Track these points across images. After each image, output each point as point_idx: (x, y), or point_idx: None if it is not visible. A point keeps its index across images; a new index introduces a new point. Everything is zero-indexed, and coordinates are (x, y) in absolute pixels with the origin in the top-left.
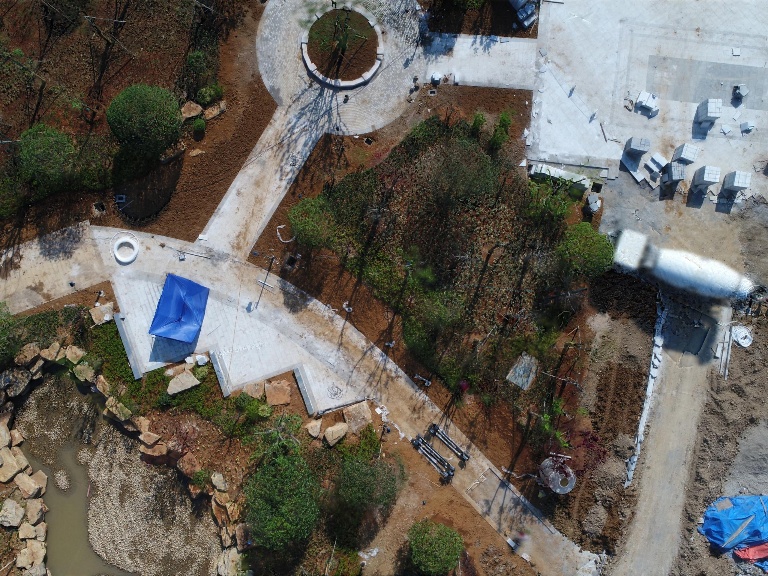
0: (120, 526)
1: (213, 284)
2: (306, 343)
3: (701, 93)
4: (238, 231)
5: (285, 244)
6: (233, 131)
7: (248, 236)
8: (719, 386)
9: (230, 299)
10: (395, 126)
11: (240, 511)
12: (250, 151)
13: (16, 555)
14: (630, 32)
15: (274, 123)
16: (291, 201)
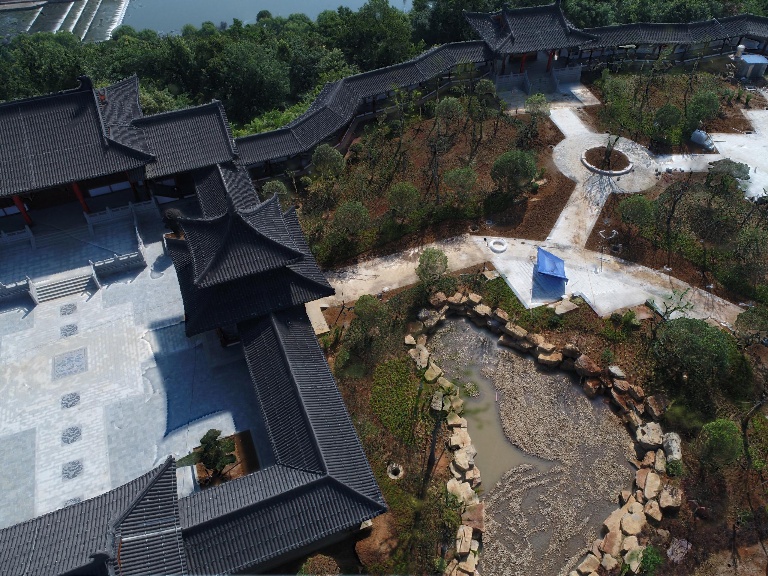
0: (532, 421)
1: (565, 260)
2: (647, 288)
3: None
4: (573, 235)
5: (608, 240)
6: (554, 192)
7: (581, 237)
8: None
9: (580, 267)
10: (655, 188)
11: (643, 391)
12: (567, 201)
13: (447, 438)
14: None
15: (577, 190)
16: (603, 220)
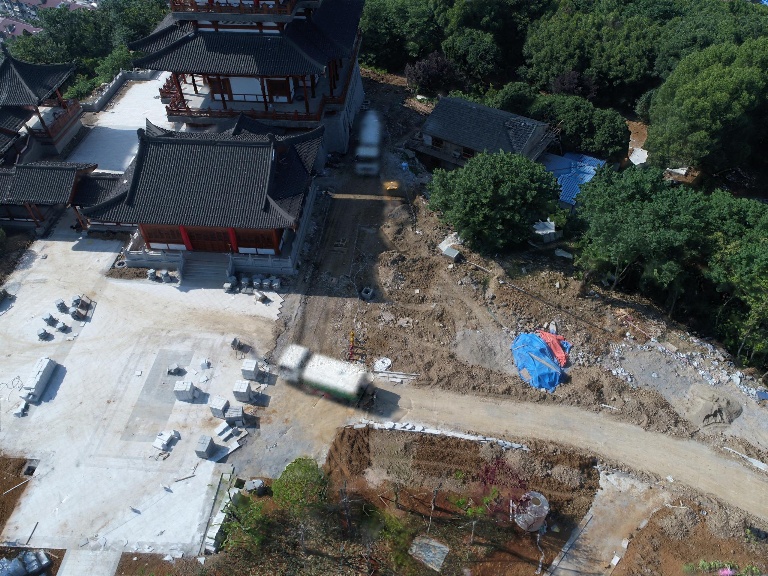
0: None
1: None
2: None
3: (167, 398)
4: None
5: None
6: None
7: None
8: (426, 379)
9: None
10: None
11: None
12: None
13: None
14: (91, 457)
15: None
16: None
